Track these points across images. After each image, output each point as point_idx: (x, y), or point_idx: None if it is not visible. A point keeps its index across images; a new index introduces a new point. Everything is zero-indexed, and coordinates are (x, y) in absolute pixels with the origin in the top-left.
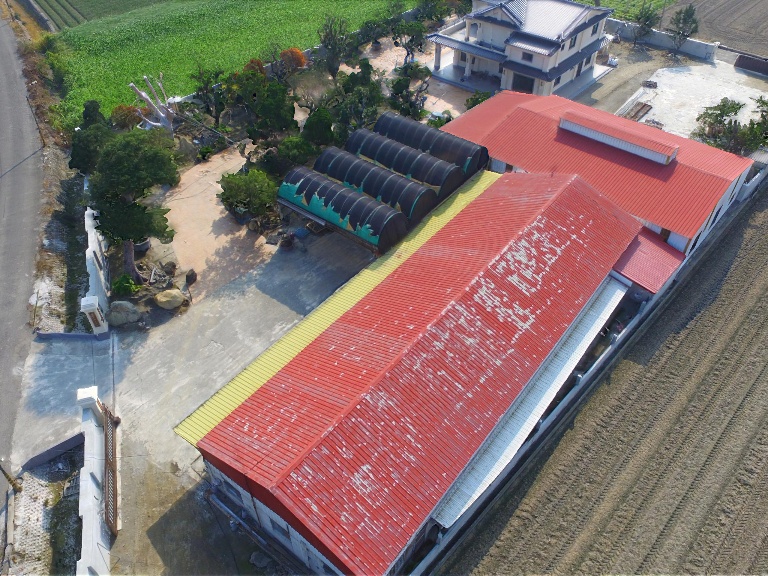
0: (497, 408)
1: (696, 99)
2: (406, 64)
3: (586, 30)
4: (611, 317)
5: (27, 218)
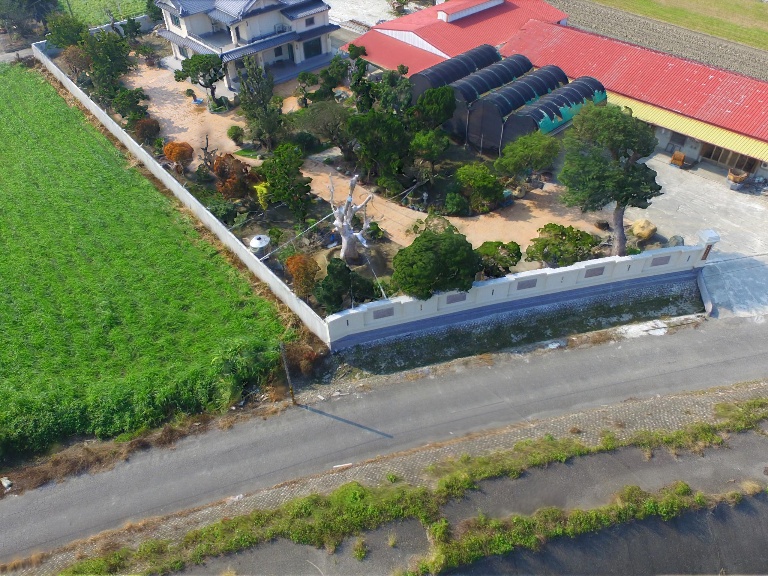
0: None
1: (346, 7)
2: (223, 98)
3: None
4: None
5: (504, 375)
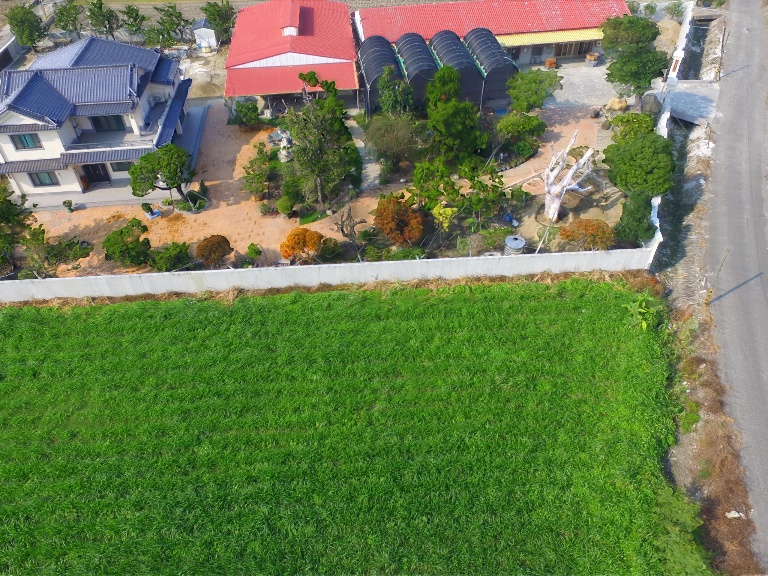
0: None
1: None
2: (194, 192)
3: None
4: None
5: (723, 209)
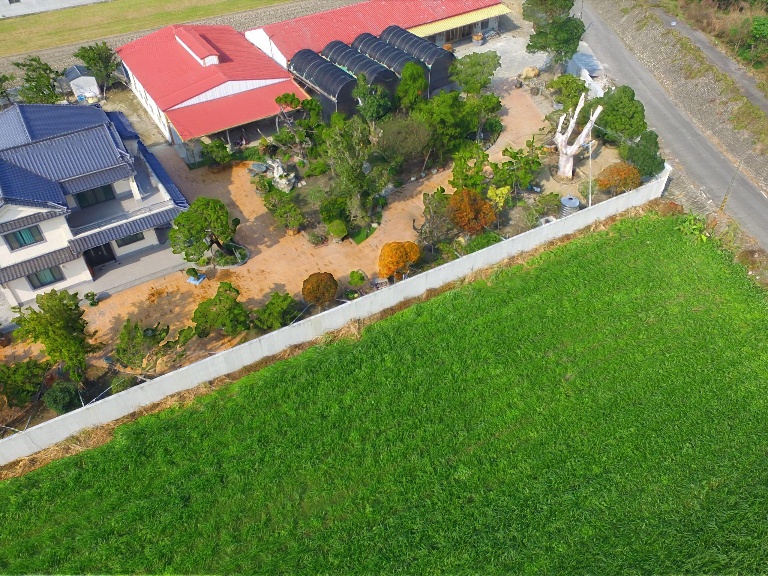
0: None
1: None
2: (230, 243)
3: None
4: None
5: (670, 136)
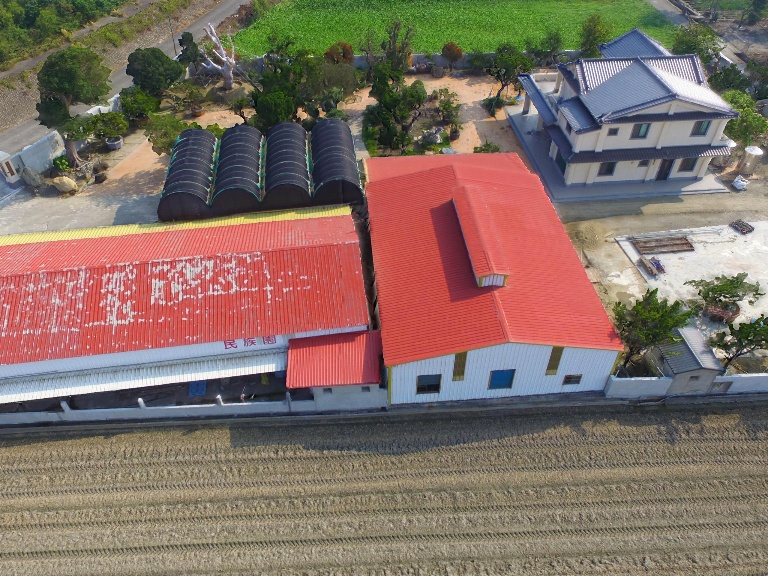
0: (9, 357)
1: None
2: (494, 97)
3: (673, 124)
4: (273, 390)
5: None
